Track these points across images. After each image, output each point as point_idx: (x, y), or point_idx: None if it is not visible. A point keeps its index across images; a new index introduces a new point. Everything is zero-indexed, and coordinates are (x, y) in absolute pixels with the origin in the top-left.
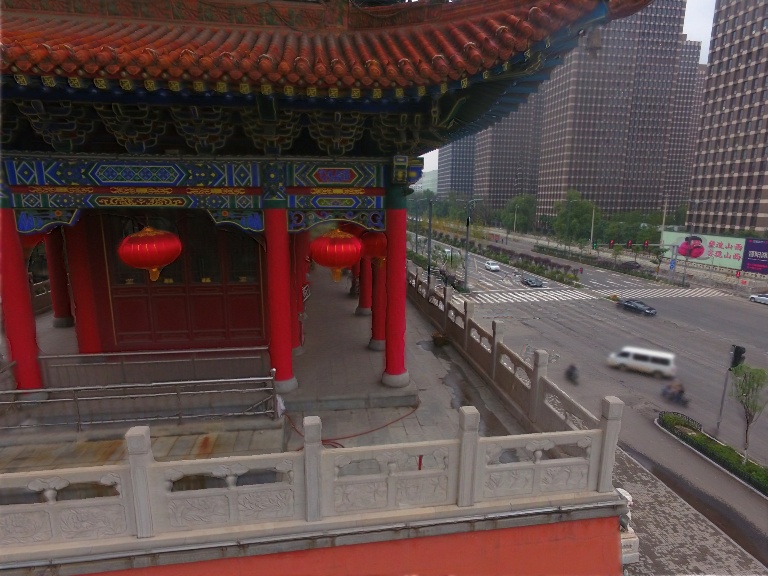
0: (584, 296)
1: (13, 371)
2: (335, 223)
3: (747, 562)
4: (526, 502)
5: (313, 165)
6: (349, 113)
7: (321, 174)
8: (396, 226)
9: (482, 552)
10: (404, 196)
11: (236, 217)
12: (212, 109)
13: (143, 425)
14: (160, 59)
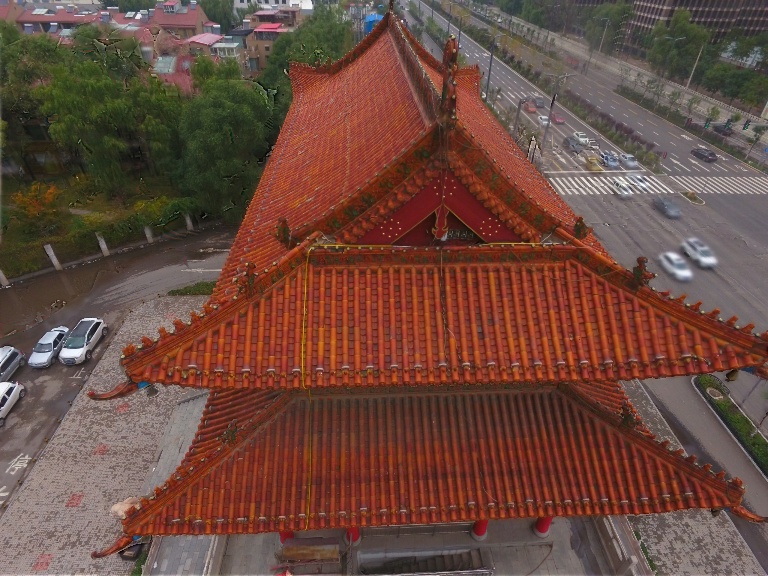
0: (660, 188)
1: None
2: None
3: (724, 522)
4: None
5: None
6: None
7: None
8: None
9: None
10: None
11: None
12: None
13: None
14: (482, 518)
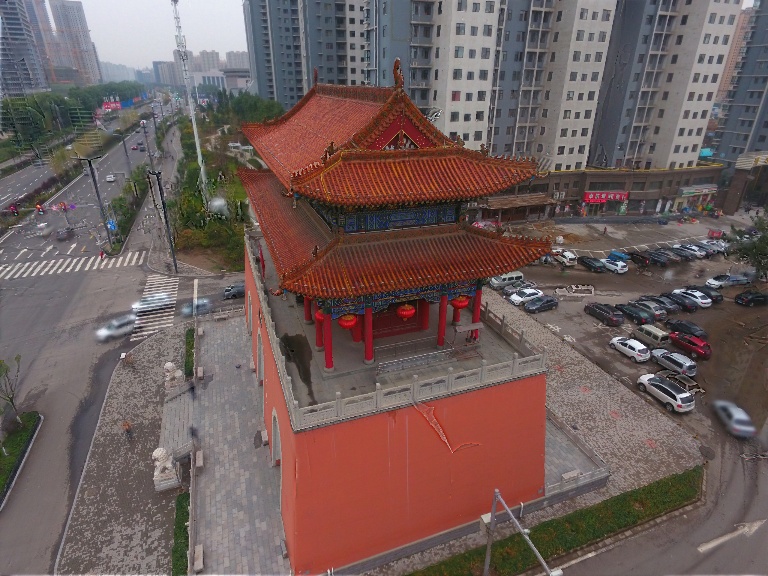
0: None
1: None
2: None
3: None
4: None
5: None
6: None
7: None
8: None
9: None
10: None
11: None
12: None
13: None
14: None
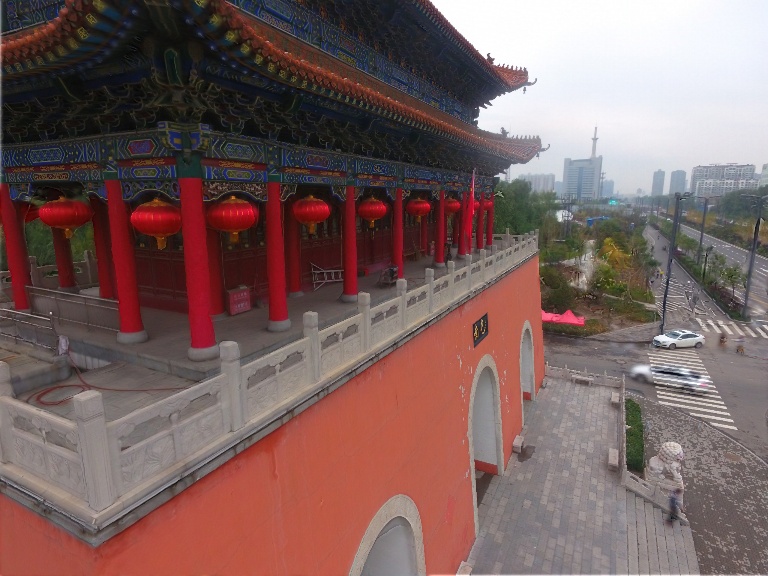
0: None
1: (6, 292)
2: (153, 193)
3: None
4: (32, 481)
5: (127, 139)
6: (122, 85)
7: (132, 147)
8: (182, 195)
9: (1, 512)
10: (185, 164)
11: (96, 188)
12: (54, 98)
13: (4, 339)
14: None
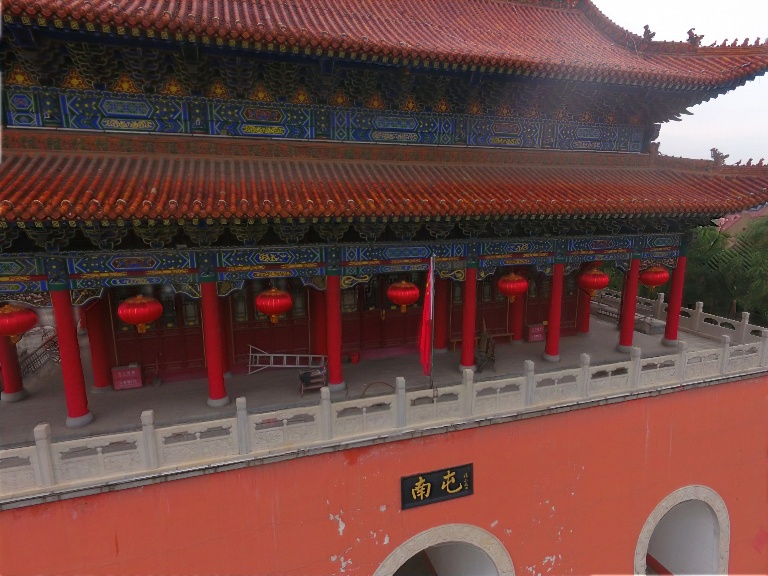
0: None
1: (55, 331)
2: None
3: None
4: None
5: None
6: None
7: None
8: None
9: None
10: None
11: None
12: None
13: None
14: None
